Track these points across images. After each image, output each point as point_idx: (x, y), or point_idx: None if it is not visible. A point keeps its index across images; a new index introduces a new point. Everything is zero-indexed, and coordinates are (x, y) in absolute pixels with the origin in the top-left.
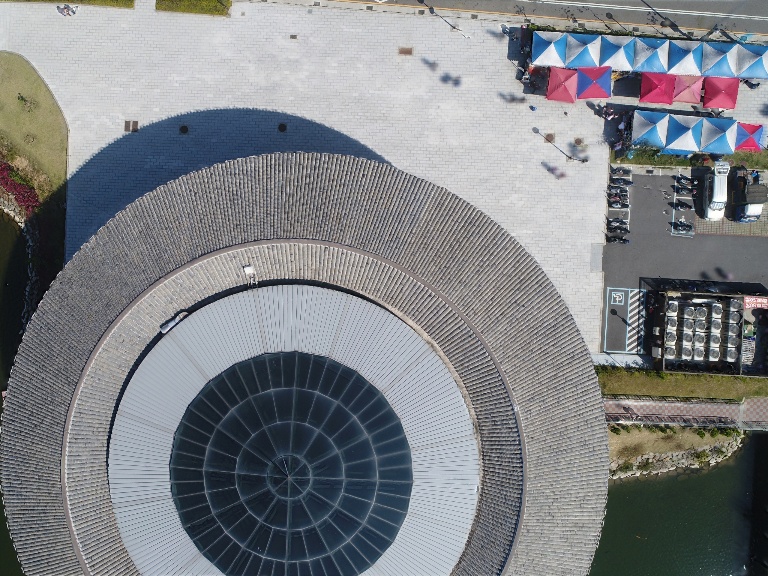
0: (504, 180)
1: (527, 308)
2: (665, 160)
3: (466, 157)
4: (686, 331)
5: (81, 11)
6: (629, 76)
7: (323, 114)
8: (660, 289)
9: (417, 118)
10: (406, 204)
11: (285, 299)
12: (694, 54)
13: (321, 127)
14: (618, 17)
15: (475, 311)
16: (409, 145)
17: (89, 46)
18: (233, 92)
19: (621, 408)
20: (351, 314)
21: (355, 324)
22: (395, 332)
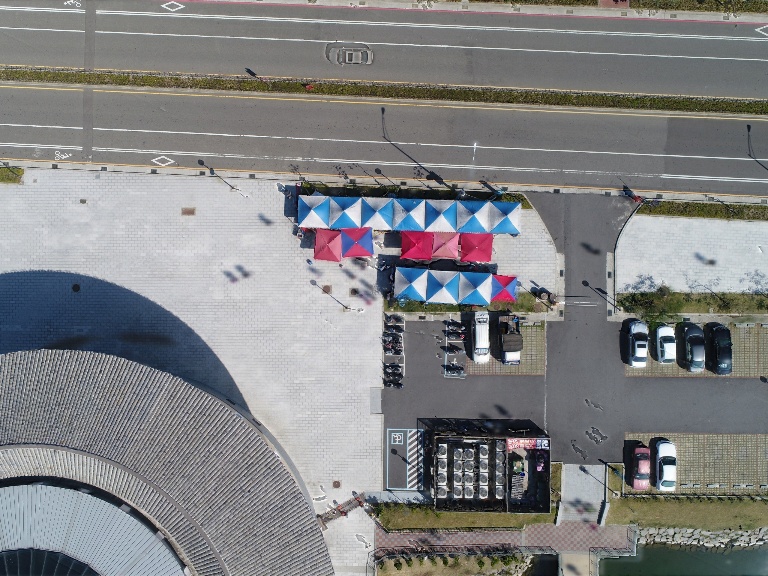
0: (286, 331)
1: (253, 493)
2: (435, 307)
3: (249, 310)
4: (456, 472)
5: None
6: (393, 232)
7: (114, 274)
8: (435, 429)
9: (202, 275)
10: (138, 399)
11: (20, 499)
12: (446, 215)
13: (112, 286)
14: (386, 172)
15: (196, 504)
16: (195, 301)
17: None
18: (29, 255)
19: (406, 541)
20: (82, 511)
21: (86, 520)
22: (123, 526)
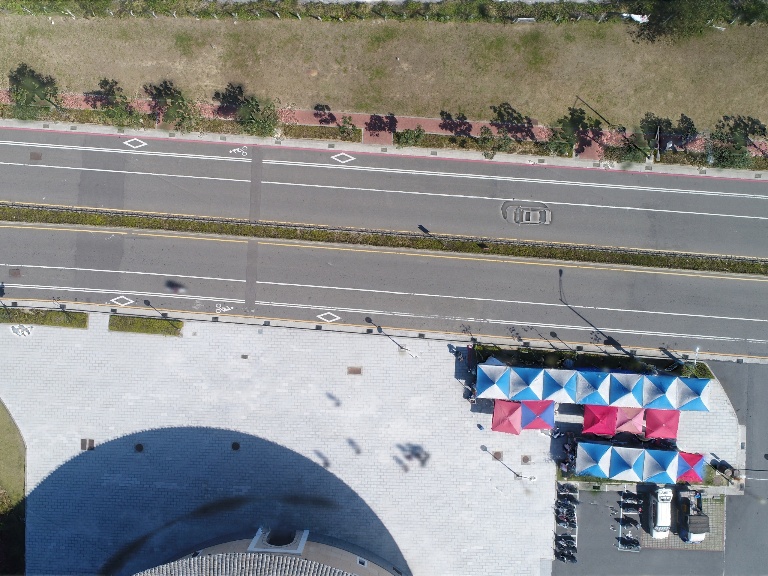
0: (454, 497)
1: None
2: None
3: (416, 475)
4: None
5: (36, 331)
6: None
7: (275, 433)
8: None
9: (367, 437)
10: None
11: None
12: (634, 392)
13: (273, 446)
14: (562, 336)
15: None
16: (360, 463)
17: (44, 366)
18: (186, 411)
19: None
20: None
21: None
22: None
